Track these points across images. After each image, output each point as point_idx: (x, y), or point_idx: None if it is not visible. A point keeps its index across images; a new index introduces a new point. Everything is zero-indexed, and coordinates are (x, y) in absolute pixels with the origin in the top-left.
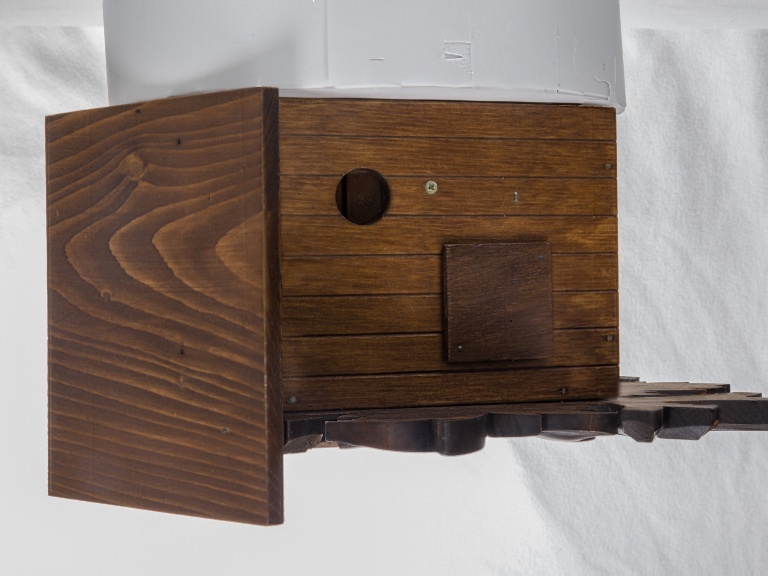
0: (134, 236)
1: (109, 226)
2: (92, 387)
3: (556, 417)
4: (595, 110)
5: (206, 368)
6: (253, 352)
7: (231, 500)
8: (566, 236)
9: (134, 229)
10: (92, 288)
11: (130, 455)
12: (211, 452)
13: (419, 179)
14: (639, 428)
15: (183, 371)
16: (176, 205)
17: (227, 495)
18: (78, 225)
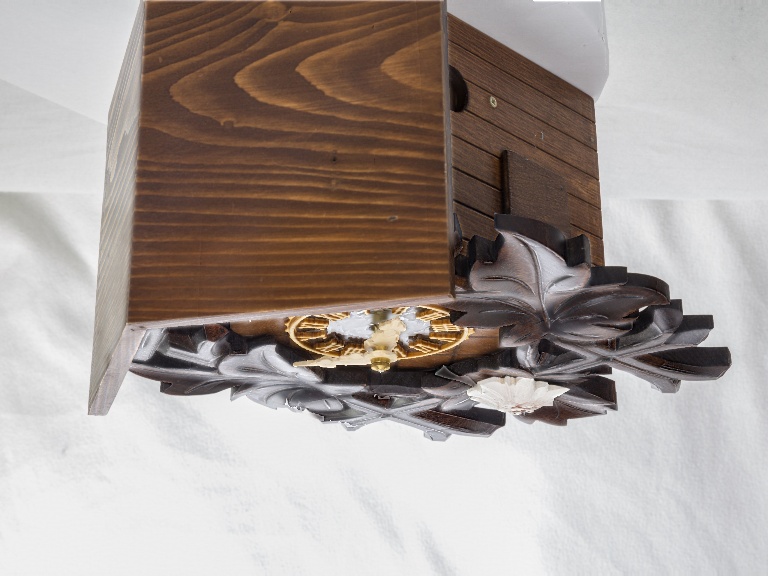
0: (271, 68)
1: (236, 63)
2: (203, 208)
3: (632, 275)
4: (583, 94)
5: (368, 168)
6: (430, 146)
7: (401, 279)
8: (571, 181)
9: (271, 62)
10: (208, 119)
11: (258, 262)
12: (374, 241)
13: (485, 92)
14: (668, 316)
15: (336, 175)
16: (329, 36)
17: (396, 275)
18: (190, 67)
